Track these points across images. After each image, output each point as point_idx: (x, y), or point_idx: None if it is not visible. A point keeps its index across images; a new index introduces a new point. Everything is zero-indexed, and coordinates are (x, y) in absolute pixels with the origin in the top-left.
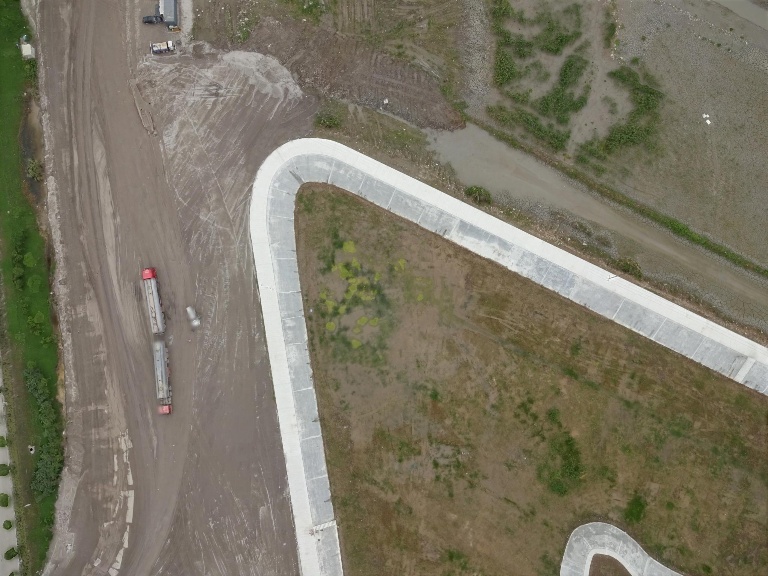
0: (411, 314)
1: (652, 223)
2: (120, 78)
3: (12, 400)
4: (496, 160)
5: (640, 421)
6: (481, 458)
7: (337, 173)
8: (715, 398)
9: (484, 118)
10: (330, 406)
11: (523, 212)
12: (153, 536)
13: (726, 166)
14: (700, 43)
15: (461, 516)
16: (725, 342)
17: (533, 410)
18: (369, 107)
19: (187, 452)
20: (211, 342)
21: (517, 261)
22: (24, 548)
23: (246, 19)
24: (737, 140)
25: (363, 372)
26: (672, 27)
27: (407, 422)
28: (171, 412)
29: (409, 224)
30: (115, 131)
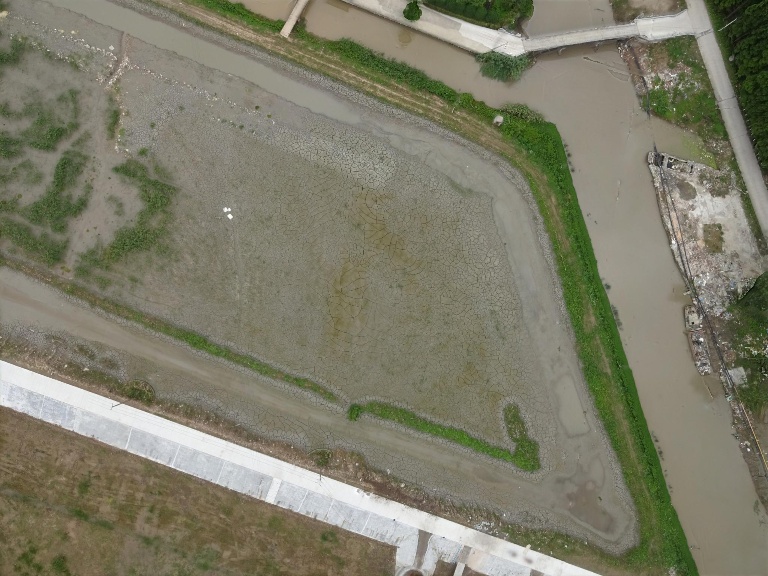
0: None
1: (166, 337)
2: None
3: None
4: None
5: (161, 558)
6: None
7: None
8: (246, 523)
9: None
10: None
11: (12, 339)
12: None
13: (251, 265)
14: (220, 126)
15: None
16: (247, 464)
17: (36, 560)
18: None
19: None
20: None
21: (7, 396)
22: None
23: None
24: (264, 234)
25: None
26: (186, 110)
27: None
28: None
29: None
30: None
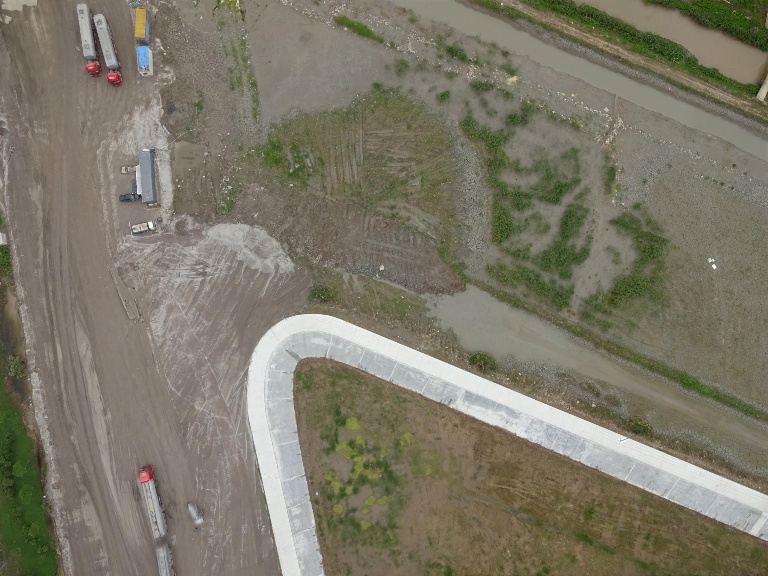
0: (420, 489)
1: (661, 378)
2: (100, 262)
3: None
4: (499, 322)
5: None
6: None
7: (335, 348)
8: (731, 553)
9: (484, 278)
10: None
11: (529, 376)
12: None
13: (734, 312)
14: (703, 183)
15: None
16: (739, 498)
17: None
18: (365, 275)
19: None
20: (216, 539)
21: (526, 428)
22: None
23: (229, 187)
24: (744, 284)
25: (374, 554)
26: (674, 167)
27: None
28: None
29: (413, 395)
30: (99, 320)
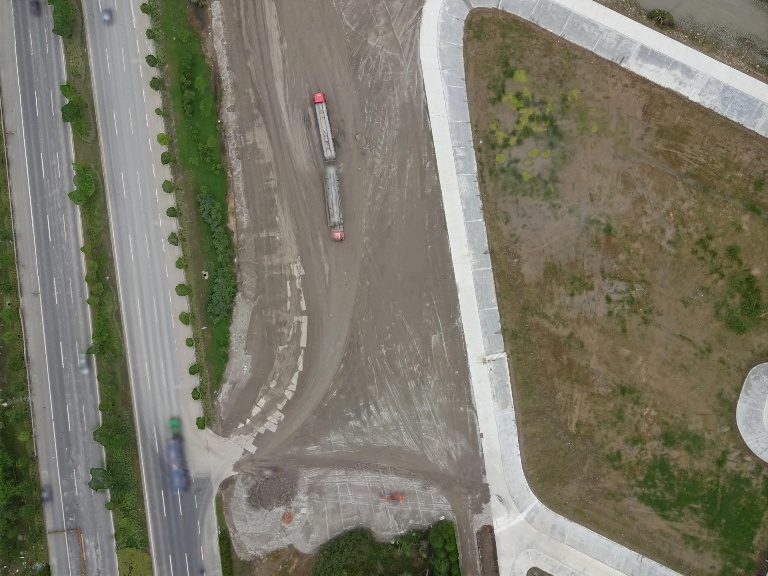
0: (585, 146)
1: None
2: None
3: (186, 225)
4: None
5: None
6: (656, 294)
7: None
8: None
9: None
10: (500, 239)
11: (708, 38)
12: (327, 360)
13: None
14: None
15: (634, 352)
16: None
17: (712, 247)
18: None
19: (359, 280)
20: (381, 170)
21: (700, 90)
22: (203, 368)
23: None
24: None
25: (534, 205)
26: None
27: (579, 257)
28: (343, 239)
29: (583, 52)
30: None
